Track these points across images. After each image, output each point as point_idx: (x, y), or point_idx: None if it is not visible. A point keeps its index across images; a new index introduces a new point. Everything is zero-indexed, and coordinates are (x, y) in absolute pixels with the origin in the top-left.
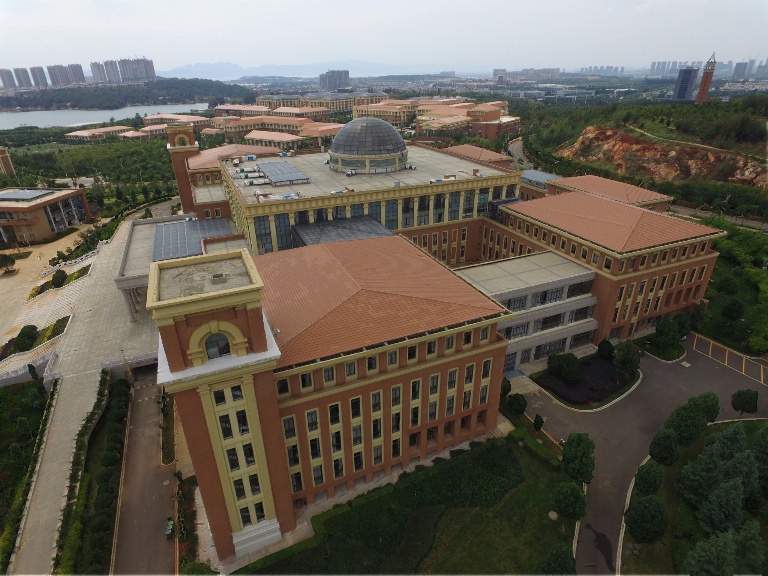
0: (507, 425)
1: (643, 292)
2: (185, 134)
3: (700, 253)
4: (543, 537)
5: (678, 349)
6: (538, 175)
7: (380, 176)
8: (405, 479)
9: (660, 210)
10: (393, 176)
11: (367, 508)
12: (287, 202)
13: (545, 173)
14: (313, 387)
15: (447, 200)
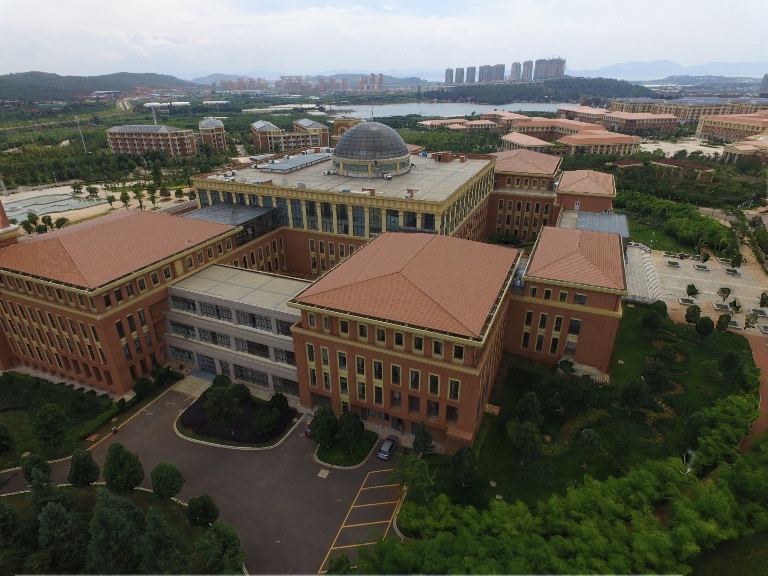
0: (129, 398)
1: (346, 367)
2: (346, 126)
3: (453, 359)
4: (0, 457)
5: (348, 457)
6: (605, 223)
7: (342, 179)
8: (53, 384)
9: (604, 305)
10: (350, 181)
11: (24, 384)
12: (216, 182)
13: (623, 223)
14: (4, 285)
15: (350, 213)
